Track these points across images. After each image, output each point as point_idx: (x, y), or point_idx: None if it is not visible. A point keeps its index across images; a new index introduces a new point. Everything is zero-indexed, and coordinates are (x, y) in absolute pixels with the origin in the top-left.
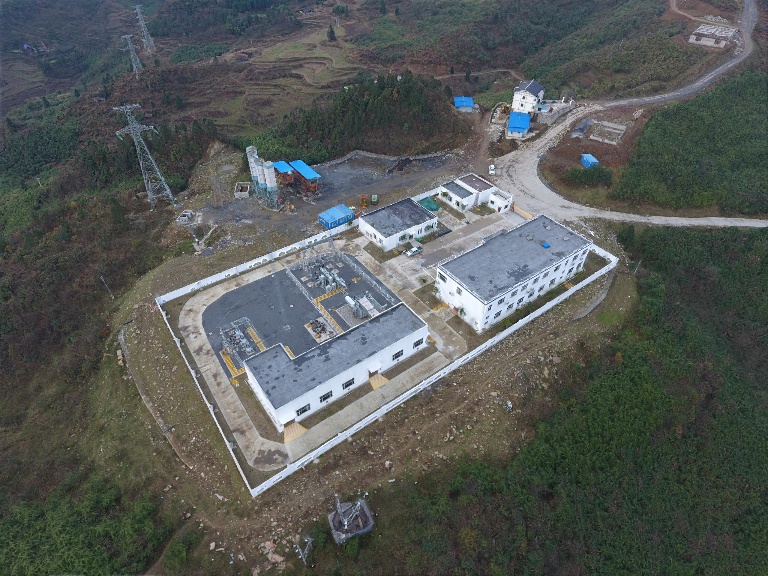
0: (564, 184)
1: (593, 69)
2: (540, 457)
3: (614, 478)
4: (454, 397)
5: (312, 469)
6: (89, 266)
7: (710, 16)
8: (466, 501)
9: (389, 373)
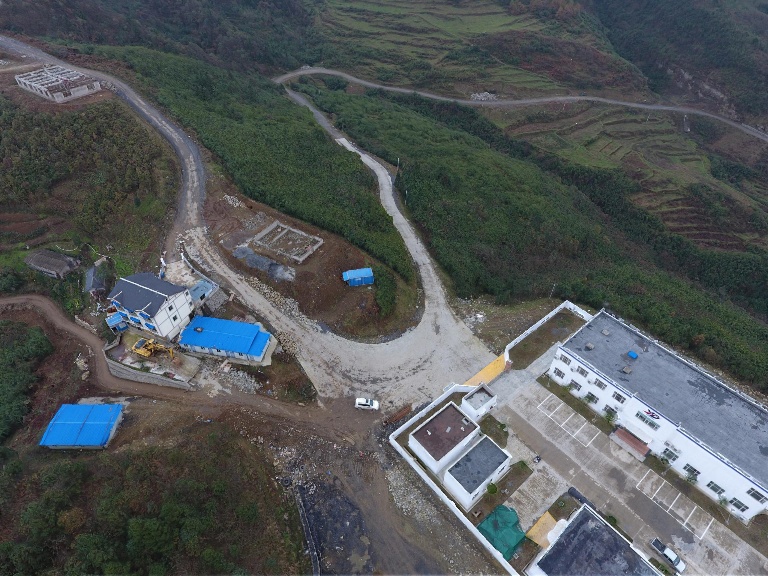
0: (388, 318)
1: None
2: None
3: None
4: None
5: None
6: None
7: None
8: None
9: None
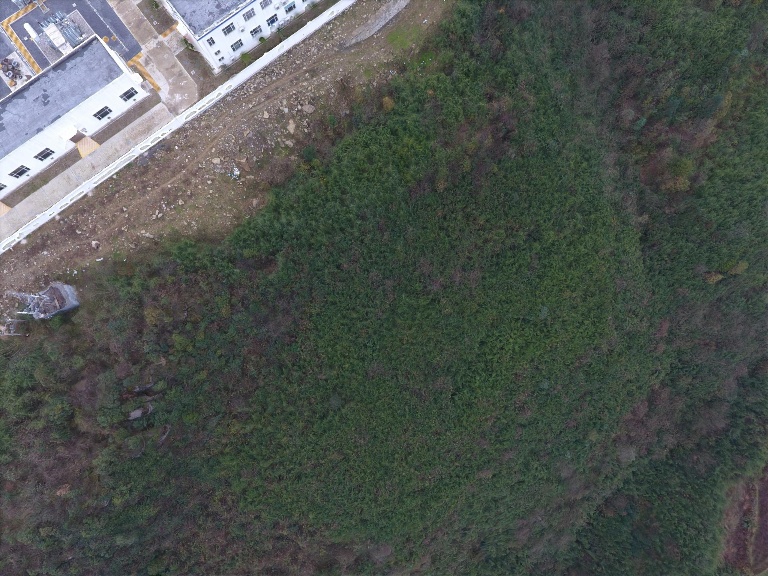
0: None
1: None
2: (260, 228)
3: (356, 236)
4: (170, 166)
5: (20, 250)
6: None
7: None
8: (153, 285)
9: (100, 135)
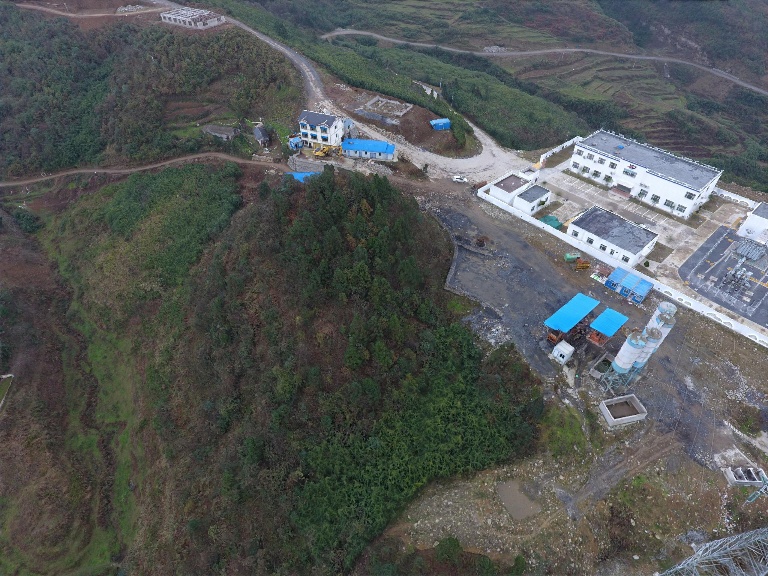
0: None
1: (174, 98)
2: None
3: None
4: None
5: None
6: None
7: (123, 8)
8: None
9: None
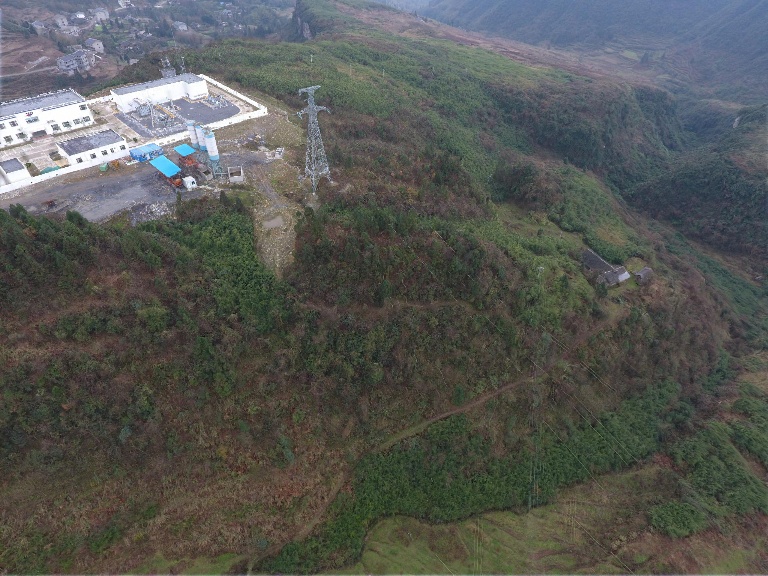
0: None
1: None
2: None
3: None
4: None
5: None
6: None
7: None
8: None
9: None
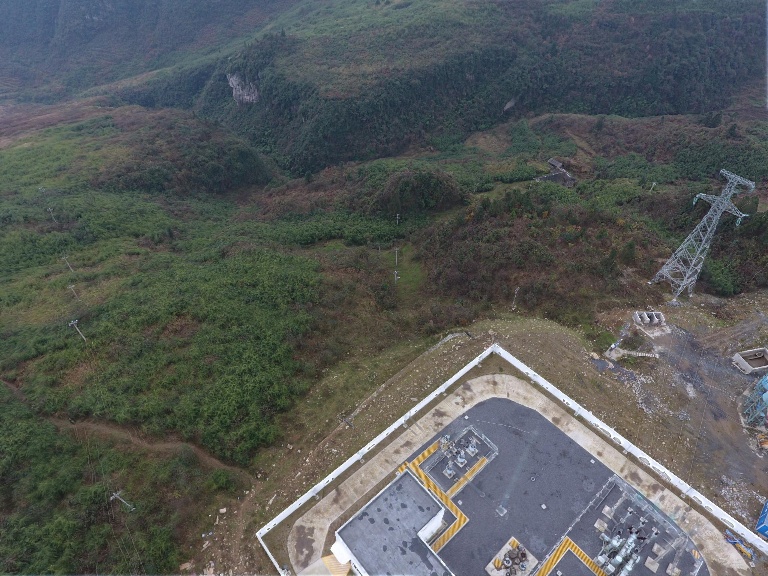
0: None
1: None
2: None
3: None
4: None
5: None
6: (541, 273)
7: None
8: None
9: None
